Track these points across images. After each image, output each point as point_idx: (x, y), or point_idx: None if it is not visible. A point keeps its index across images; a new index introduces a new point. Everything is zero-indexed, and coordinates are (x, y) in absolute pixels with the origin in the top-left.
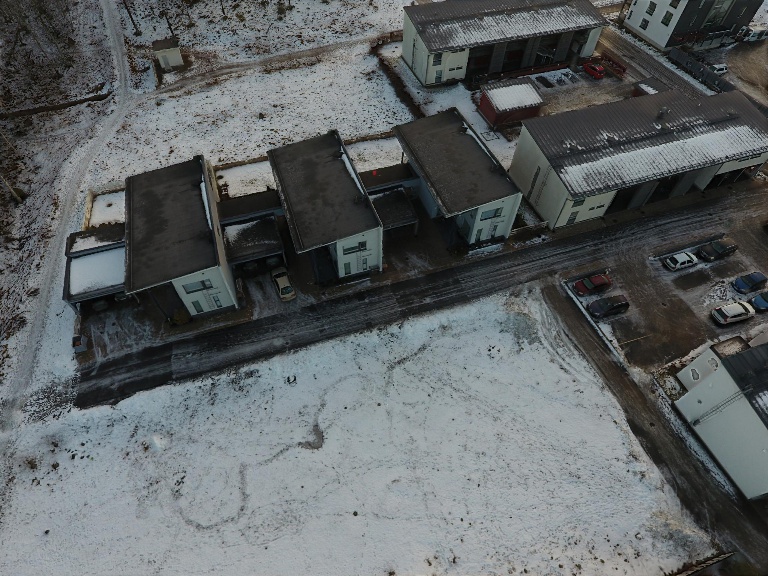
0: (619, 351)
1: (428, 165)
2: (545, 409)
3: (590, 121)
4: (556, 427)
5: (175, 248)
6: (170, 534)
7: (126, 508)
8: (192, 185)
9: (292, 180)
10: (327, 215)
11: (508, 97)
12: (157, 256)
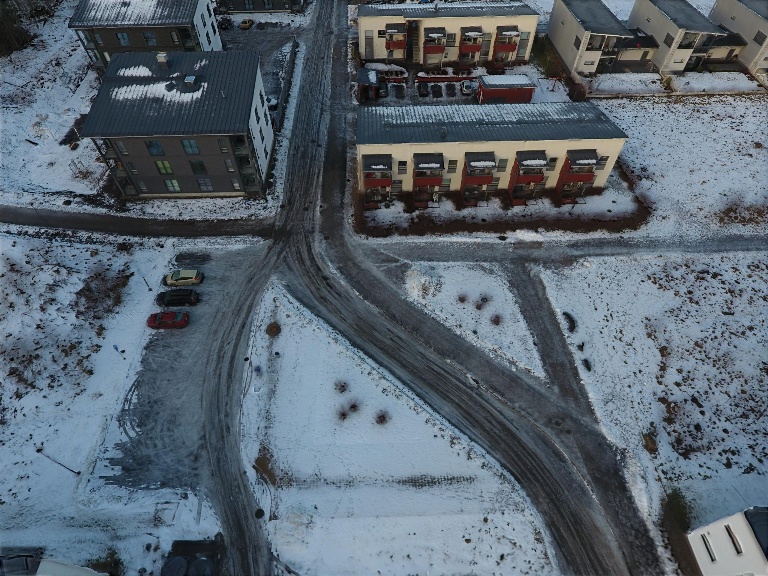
0: None
1: (609, 15)
2: (551, 1)
3: None
4: None
5: (752, 0)
6: (695, 0)
7: (715, 5)
8: (767, 17)
9: (700, 18)
10: (671, 2)
11: (513, 79)
12: (760, 0)
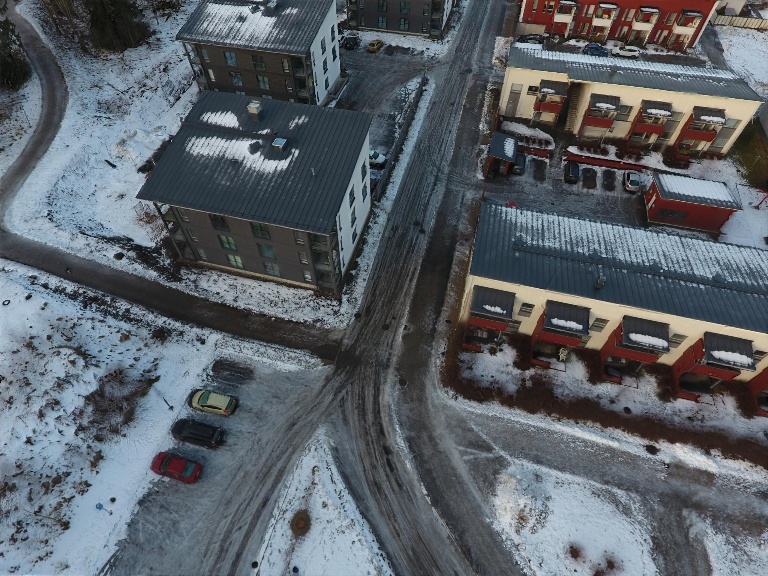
0: (709, 64)
1: None
2: (766, 66)
3: (688, 87)
4: (764, 61)
5: None
6: None
7: None
8: None
9: None
10: None
11: (706, 189)
12: None
